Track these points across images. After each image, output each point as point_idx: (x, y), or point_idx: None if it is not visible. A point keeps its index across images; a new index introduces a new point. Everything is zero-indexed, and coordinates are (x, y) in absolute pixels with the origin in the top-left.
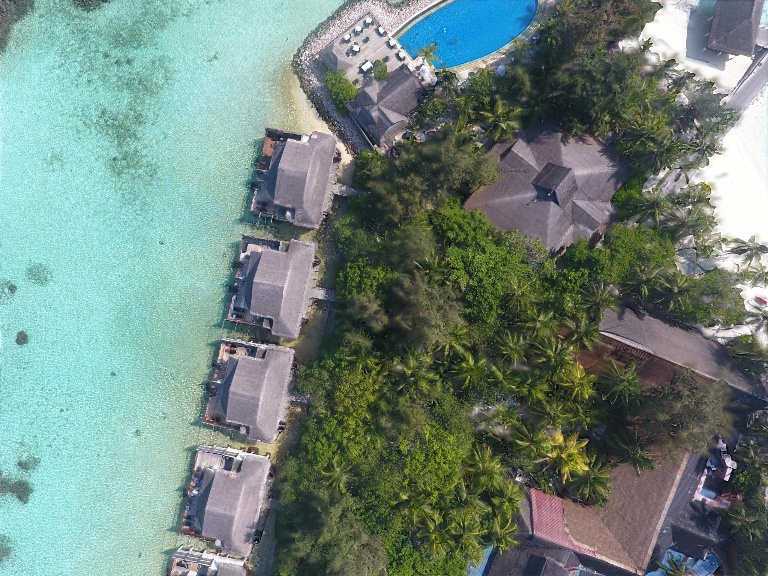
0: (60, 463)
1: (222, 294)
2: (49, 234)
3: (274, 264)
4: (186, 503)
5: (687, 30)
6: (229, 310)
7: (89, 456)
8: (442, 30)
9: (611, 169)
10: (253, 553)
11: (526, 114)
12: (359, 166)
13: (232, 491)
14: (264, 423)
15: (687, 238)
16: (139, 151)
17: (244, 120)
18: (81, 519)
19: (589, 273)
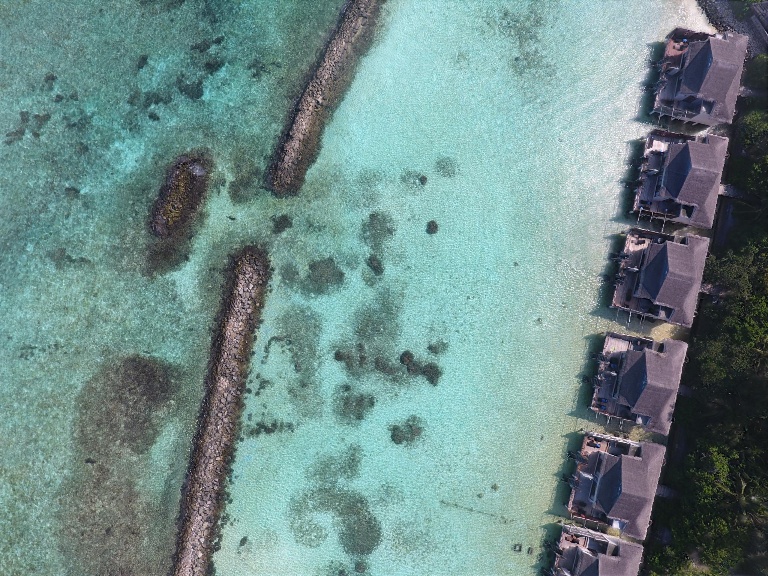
0: (467, 348)
1: (618, 190)
2: (457, 129)
3: (703, 153)
4: (586, 389)
5: None
6: (635, 203)
7: (494, 342)
8: None
9: None
10: (648, 438)
11: None
12: (761, 67)
13: (665, 368)
14: (687, 306)
15: None
16: (540, 52)
17: (638, 25)
18: (487, 402)
19: None
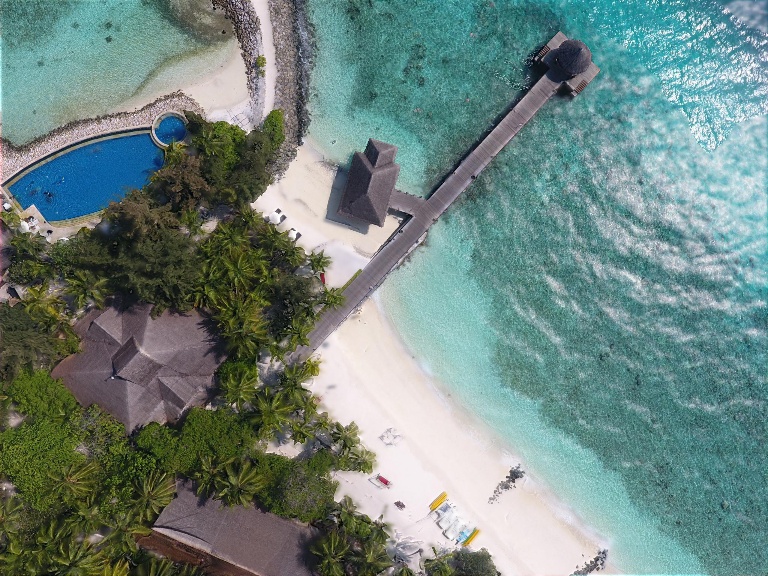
0: None
1: None
2: None
3: None
4: None
5: (331, 190)
6: None
7: None
8: (60, 180)
9: (207, 344)
10: None
11: (113, 284)
12: None
13: None
14: None
15: None
16: None
17: None
18: None
19: (157, 460)
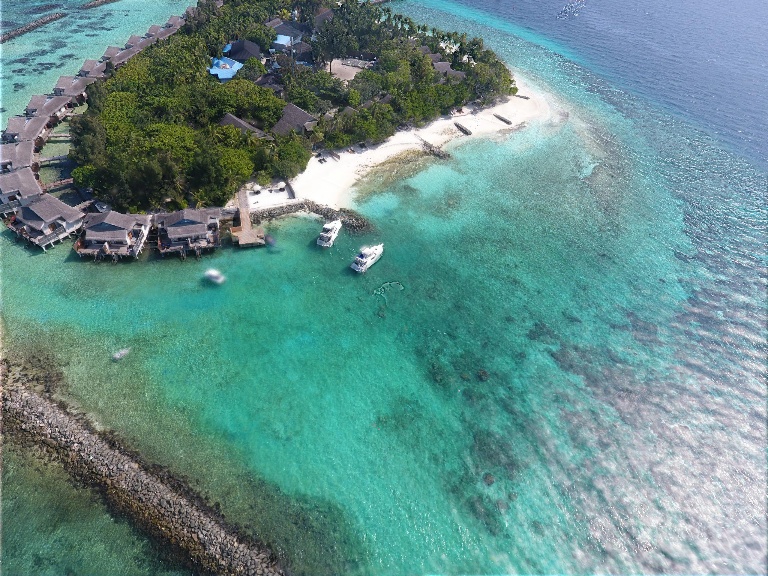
0: None
1: None
2: None
3: None
4: None
5: None
6: None
7: None
8: None
9: None
10: None
11: None
12: None
13: None
14: None
15: None
16: None
17: None
18: None
19: None
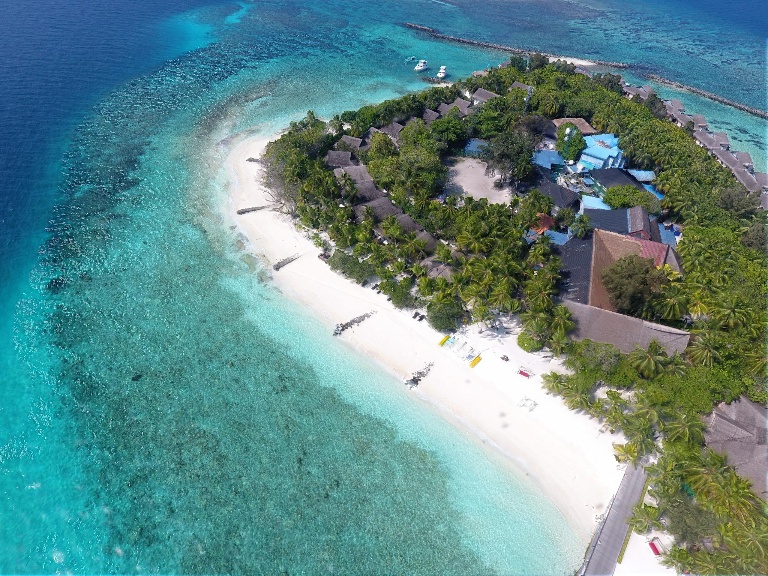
0: None
1: None
2: None
3: None
4: None
5: None
6: None
7: None
8: None
9: None
10: None
11: None
12: None
13: None
14: None
15: (606, 422)
16: None
17: None
18: None
19: None
